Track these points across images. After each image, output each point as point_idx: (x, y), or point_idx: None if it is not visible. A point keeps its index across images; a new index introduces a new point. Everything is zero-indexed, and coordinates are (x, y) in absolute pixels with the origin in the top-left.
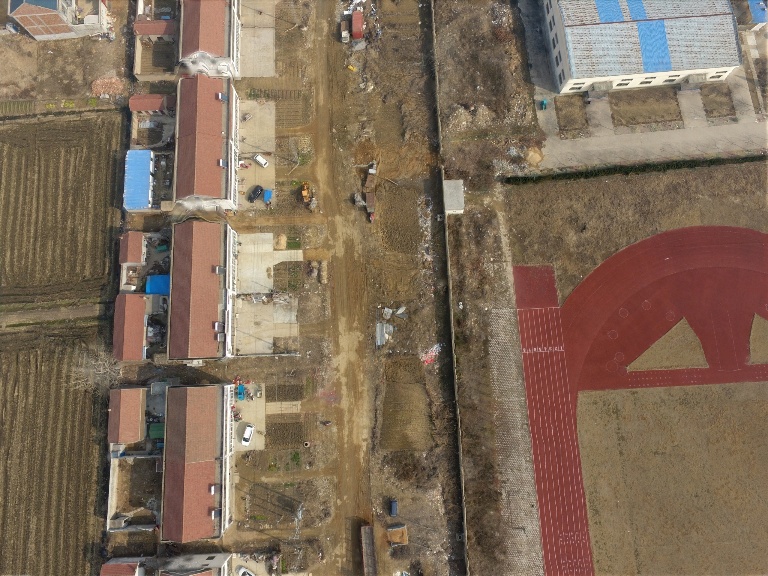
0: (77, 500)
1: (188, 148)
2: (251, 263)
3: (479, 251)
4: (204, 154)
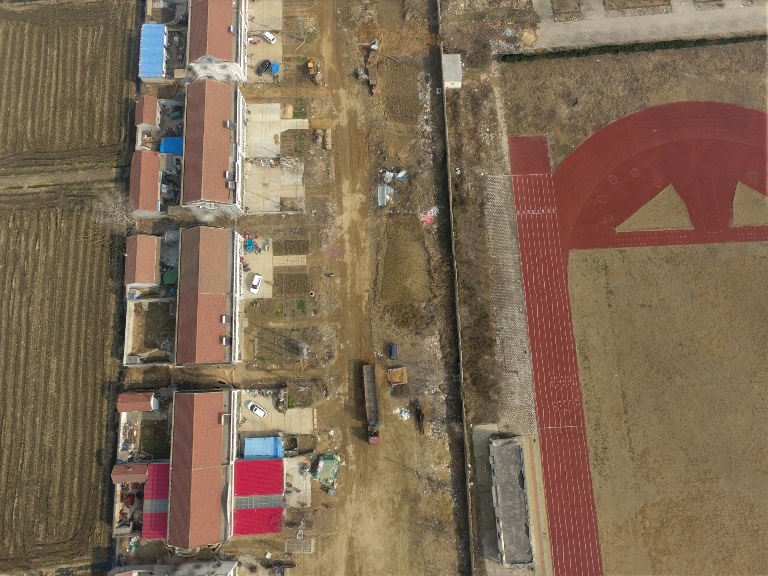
0: (95, 343)
1: (201, 15)
2: (259, 130)
3: (476, 122)
4: (216, 20)
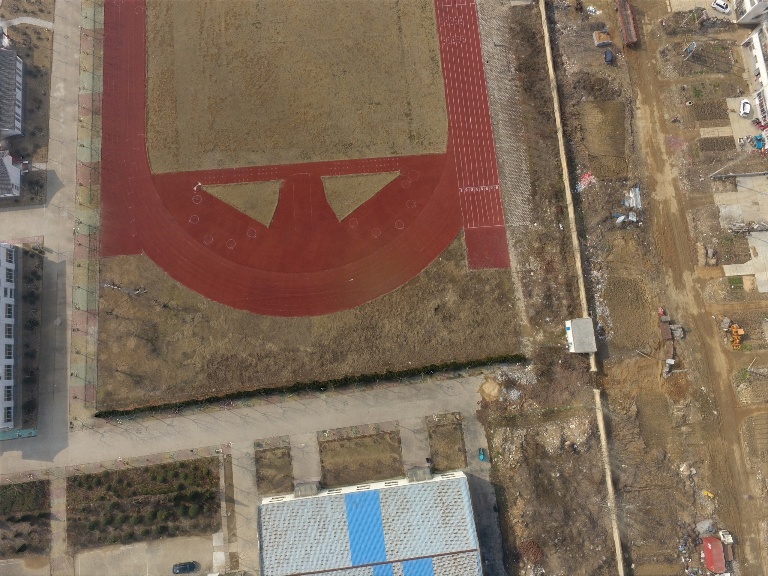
0: None
1: None
2: None
3: (546, 281)
4: None
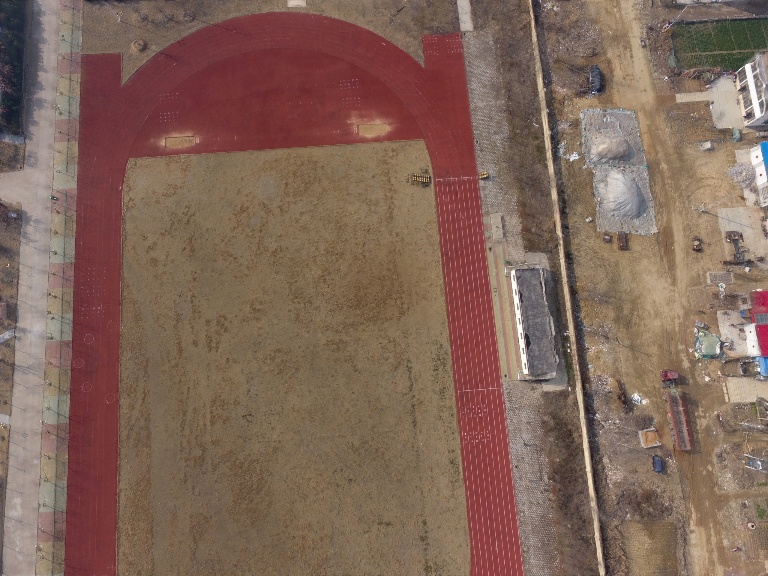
0: None
1: None
2: None
3: None
4: None
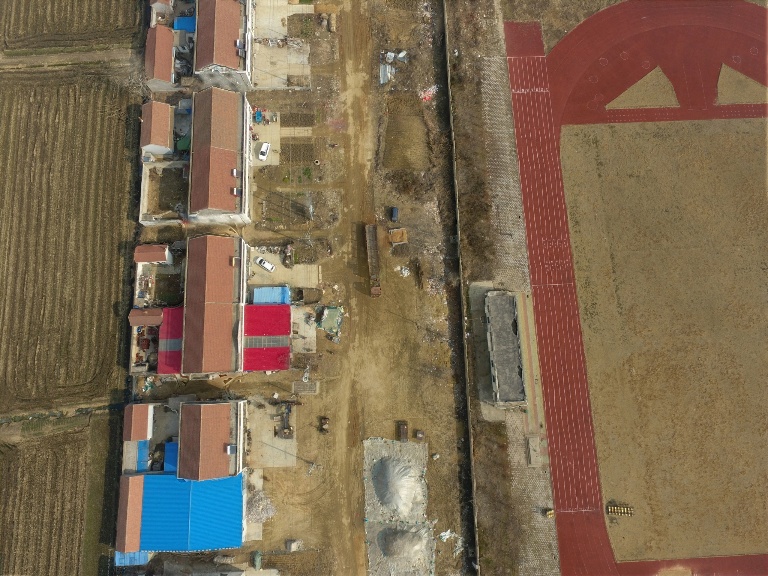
0: (112, 207)
1: None
2: (267, 14)
3: (473, 8)
4: None
